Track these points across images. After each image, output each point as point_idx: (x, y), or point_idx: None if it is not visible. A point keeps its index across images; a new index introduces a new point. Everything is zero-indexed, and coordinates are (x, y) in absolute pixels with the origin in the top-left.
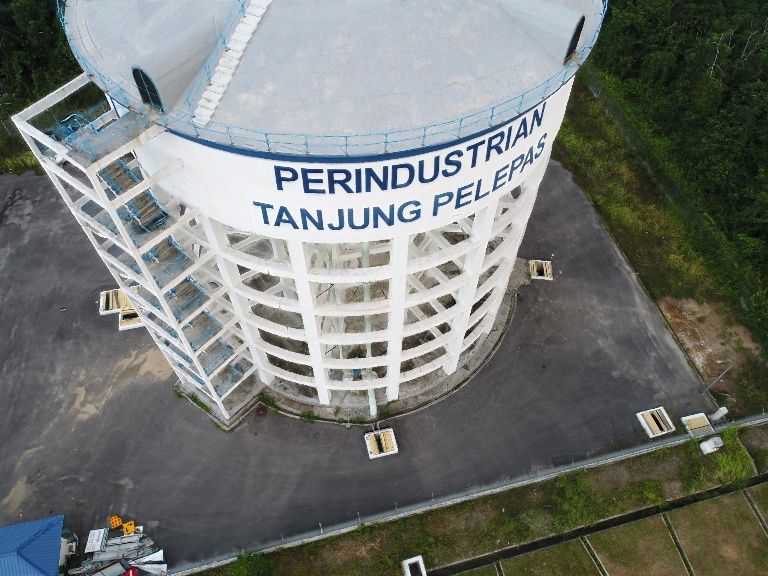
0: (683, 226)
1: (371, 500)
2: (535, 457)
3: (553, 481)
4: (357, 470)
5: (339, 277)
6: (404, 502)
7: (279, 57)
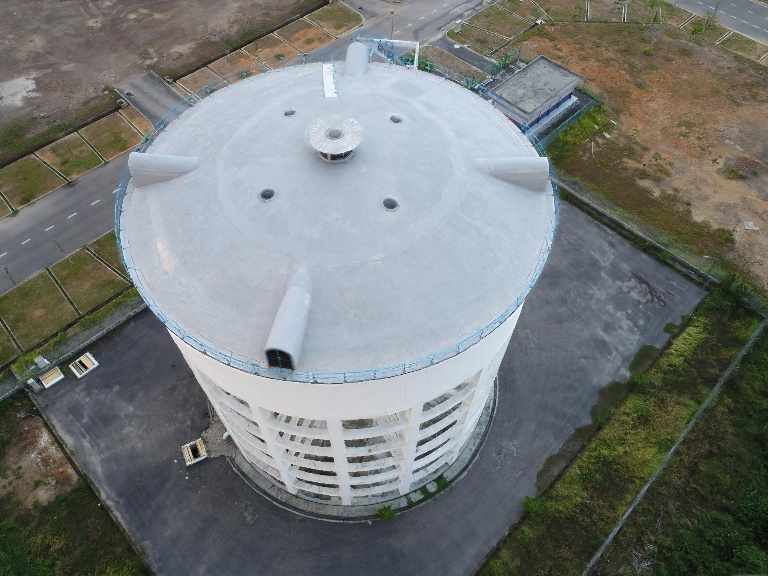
0: None
1: None
2: None
3: None
4: None
5: None
6: None
7: (302, 79)
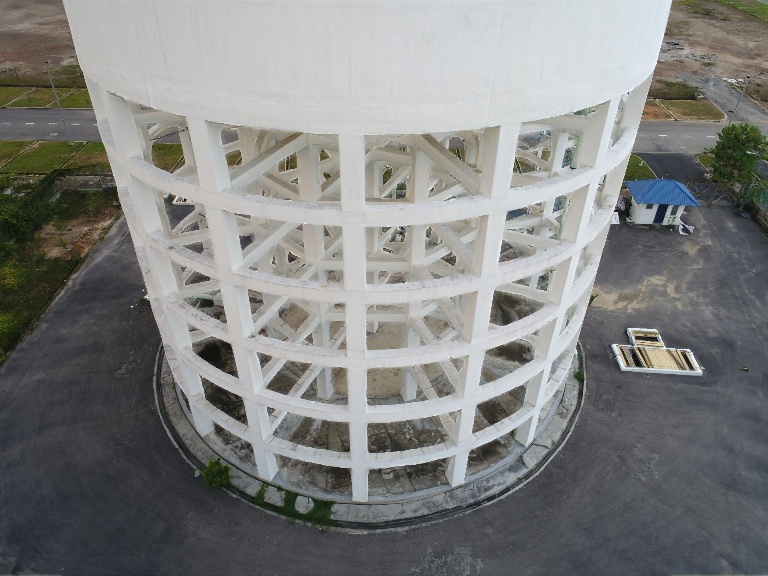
0: None
1: None
2: None
3: None
4: None
5: None
6: None
7: None
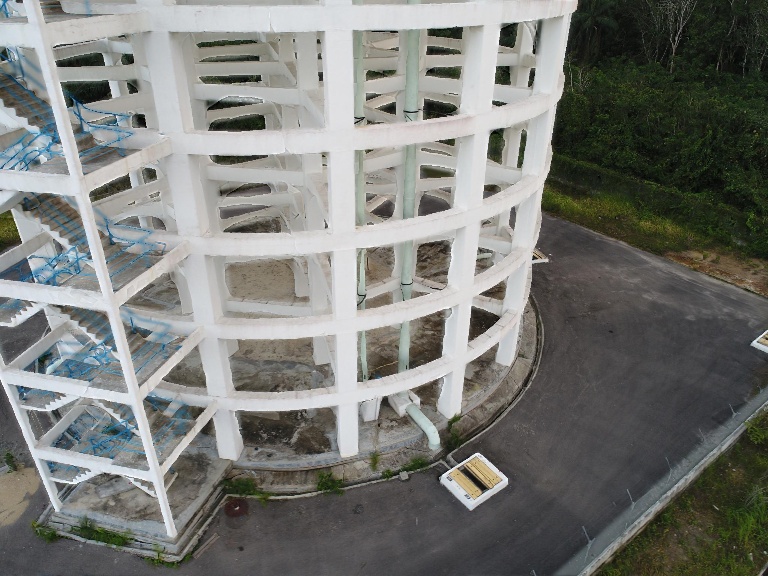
0: (629, 203)
1: (516, 574)
2: (692, 424)
3: (739, 445)
4: (460, 536)
5: (408, 8)
6: (571, 554)
7: None
